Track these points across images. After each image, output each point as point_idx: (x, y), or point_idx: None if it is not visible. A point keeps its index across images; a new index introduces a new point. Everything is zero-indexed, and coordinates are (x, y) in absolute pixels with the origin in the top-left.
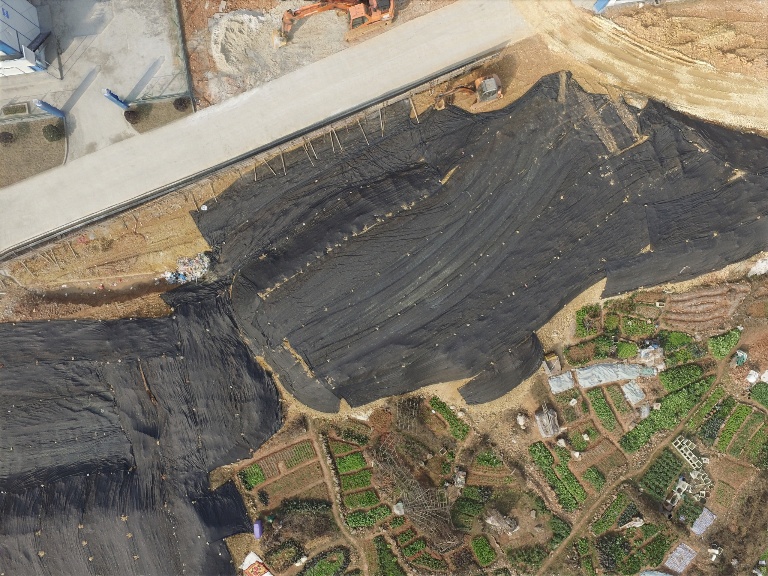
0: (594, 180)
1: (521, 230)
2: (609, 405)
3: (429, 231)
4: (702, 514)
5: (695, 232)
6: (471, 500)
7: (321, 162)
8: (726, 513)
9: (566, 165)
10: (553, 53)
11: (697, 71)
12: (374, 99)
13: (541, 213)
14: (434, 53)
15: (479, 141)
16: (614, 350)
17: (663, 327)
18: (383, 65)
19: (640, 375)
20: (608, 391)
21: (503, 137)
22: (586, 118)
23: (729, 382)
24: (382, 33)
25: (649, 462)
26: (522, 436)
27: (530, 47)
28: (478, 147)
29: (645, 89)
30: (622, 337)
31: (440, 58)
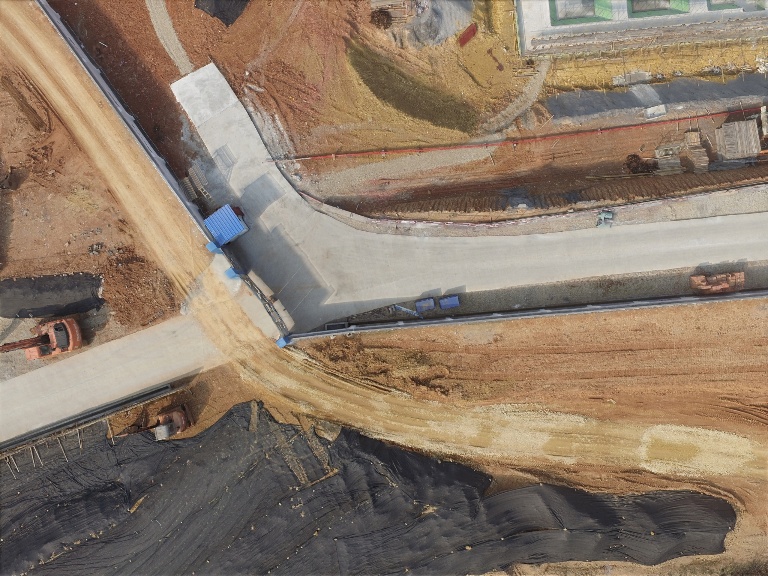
0: (285, 511)
1: (211, 560)
2: None
3: (118, 559)
4: None
5: (386, 567)
6: None
7: (23, 475)
8: None
9: (257, 495)
10: (245, 382)
11: (394, 399)
12: (73, 416)
13: (231, 543)
14: (130, 375)
15: (169, 470)
16: None
17: None
18: (81, 384)
19: None
20: None
21: (193, 466)
22: (278, 448)
23: None
24: (80, 353)
25: None
26: None
27: (222, 375)
28: (168, 476)
29: (341, 416)
30: None
31: (136, 381)
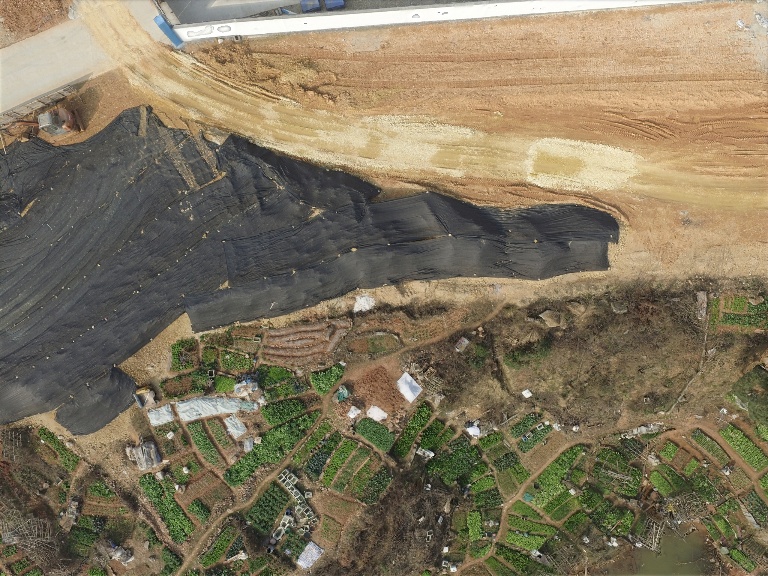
0: (174, 215)
1: (102, 264)
2: (211, 438)
3: (10, 263)
4: (308, 548)
5: (274, 269)
6: (86, 530)
7: None
8: (334, 547)
9: (147, 199)
10: (134, 87)
11: (283, 107)
12: None
13: (122, 247)
14: (20, 84)
15: (59, 174)
16: (210, 384)
17: (262, 362)
18: None
19: (239, 409)
20: (208, 424)
21: (83, 170)
22: (167, 153)
23: (334, 417)
24: None
25: (257, 495)
26: (131, 467)
27: (111, 80)
28: (58, 180)
29: (231, 124)
30: (221, 371)
31: (26, 89)
